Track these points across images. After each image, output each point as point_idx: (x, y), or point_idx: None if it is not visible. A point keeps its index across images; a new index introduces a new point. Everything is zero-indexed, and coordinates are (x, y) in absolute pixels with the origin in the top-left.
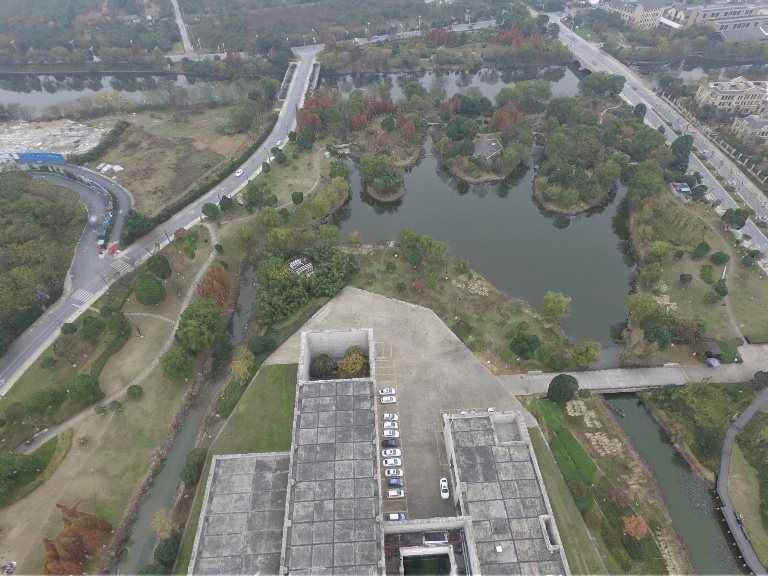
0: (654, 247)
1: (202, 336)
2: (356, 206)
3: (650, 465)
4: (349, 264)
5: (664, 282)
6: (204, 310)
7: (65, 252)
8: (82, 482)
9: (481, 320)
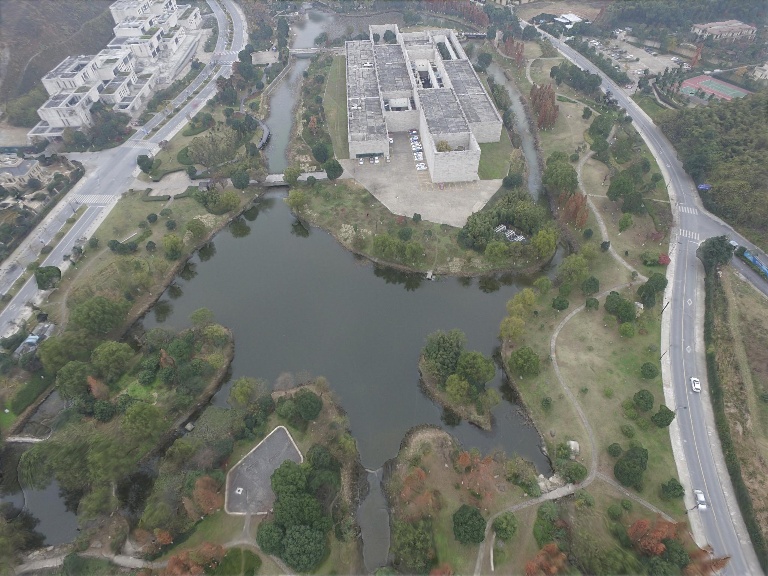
0: (176, 238)
1: (551, 164)
2: (490, 382)
3: (285, 155)
4: (467, 230)
5: (186, 234)
6: (560, 169)
7: (760, 239)
8: (567, 135)
9: (354, 206)
